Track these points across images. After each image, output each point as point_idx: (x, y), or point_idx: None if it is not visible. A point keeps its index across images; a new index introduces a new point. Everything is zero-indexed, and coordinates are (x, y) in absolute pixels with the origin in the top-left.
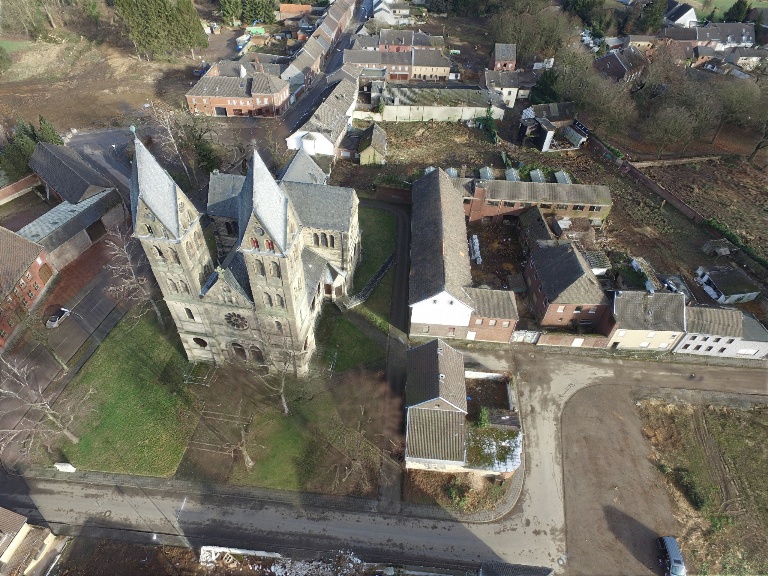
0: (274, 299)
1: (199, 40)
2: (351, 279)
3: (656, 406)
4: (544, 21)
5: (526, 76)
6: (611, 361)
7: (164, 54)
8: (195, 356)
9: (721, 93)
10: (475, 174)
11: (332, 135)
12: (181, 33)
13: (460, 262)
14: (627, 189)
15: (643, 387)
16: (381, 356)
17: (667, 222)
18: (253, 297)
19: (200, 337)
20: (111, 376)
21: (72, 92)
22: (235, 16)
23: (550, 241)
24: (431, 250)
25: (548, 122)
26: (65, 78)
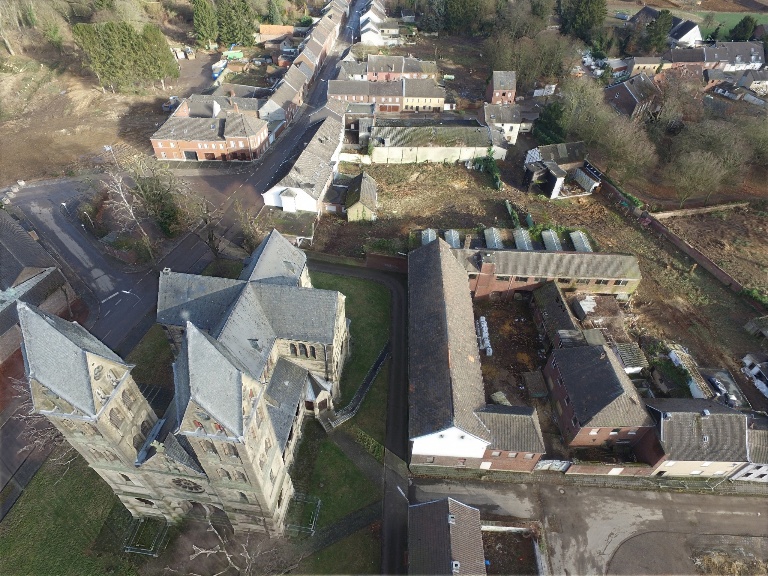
0: (233, 473)
1: (169, 70)
2: (338, 388)
3: (720, 565)
4: (544, 45)
5: (526, 105)
6: (657, 495)
7: (131, 85)
8: (141, 512)
9: (747, 132)
10: (479, 236)
11: (315, 189)
12: (149, 63)
13: (470, 372)
14: (650, 246)
15: (700, 535)
16: (376, 498)
17: (700, 290)
18: (205, 471)
19: (143, 498)
20: (32, 543)
21: (24, 133)
22: (211, 39)
23: (574, 332)
24: (434, 358)
25: (557, 167)
26: (19, 115)
